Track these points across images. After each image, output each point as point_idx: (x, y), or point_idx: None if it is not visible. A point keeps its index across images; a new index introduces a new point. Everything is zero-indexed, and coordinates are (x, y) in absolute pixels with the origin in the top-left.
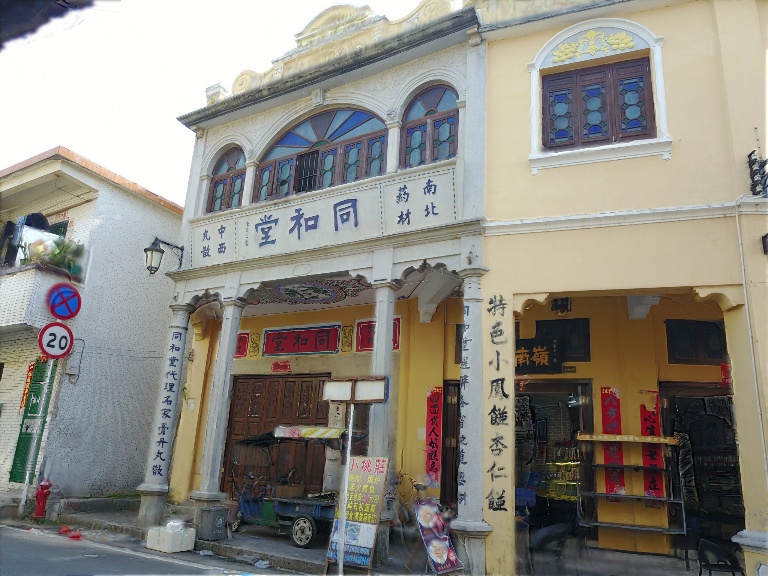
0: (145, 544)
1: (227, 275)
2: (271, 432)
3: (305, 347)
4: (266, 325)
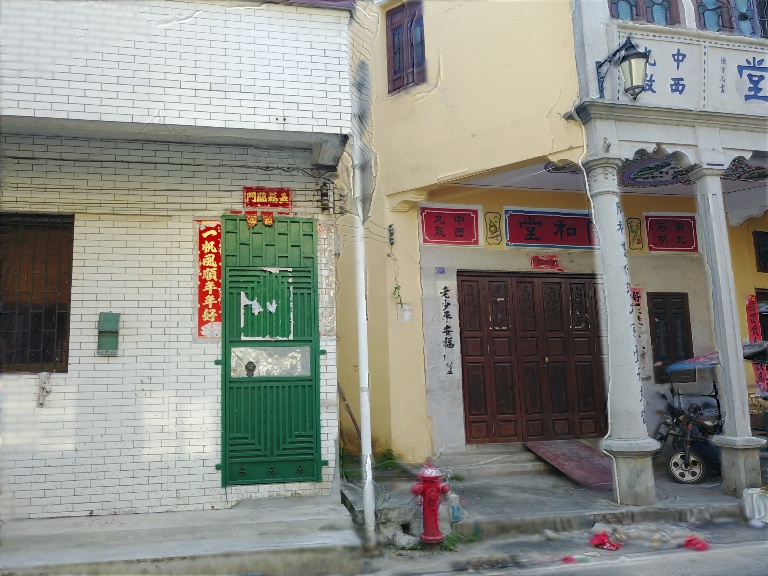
0: (764, 524)
1: (697, 129)
2: (763, 350)
3: (574, 239)
4: (508, 202)
